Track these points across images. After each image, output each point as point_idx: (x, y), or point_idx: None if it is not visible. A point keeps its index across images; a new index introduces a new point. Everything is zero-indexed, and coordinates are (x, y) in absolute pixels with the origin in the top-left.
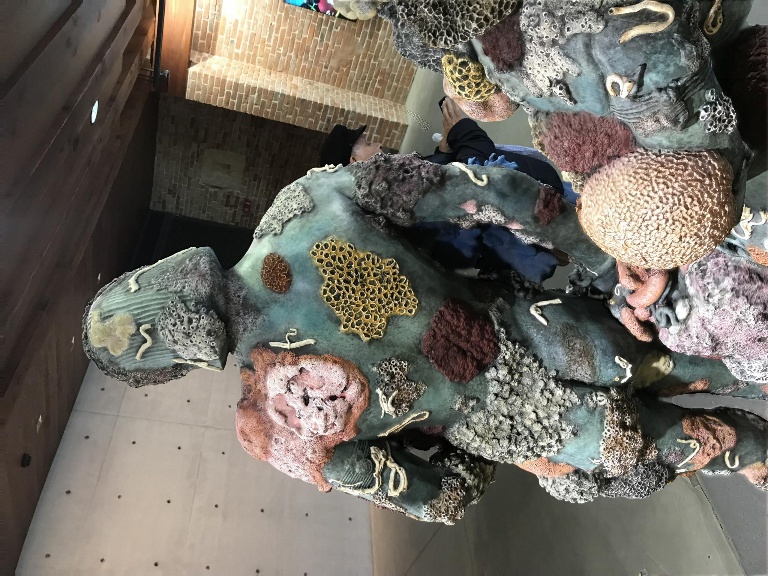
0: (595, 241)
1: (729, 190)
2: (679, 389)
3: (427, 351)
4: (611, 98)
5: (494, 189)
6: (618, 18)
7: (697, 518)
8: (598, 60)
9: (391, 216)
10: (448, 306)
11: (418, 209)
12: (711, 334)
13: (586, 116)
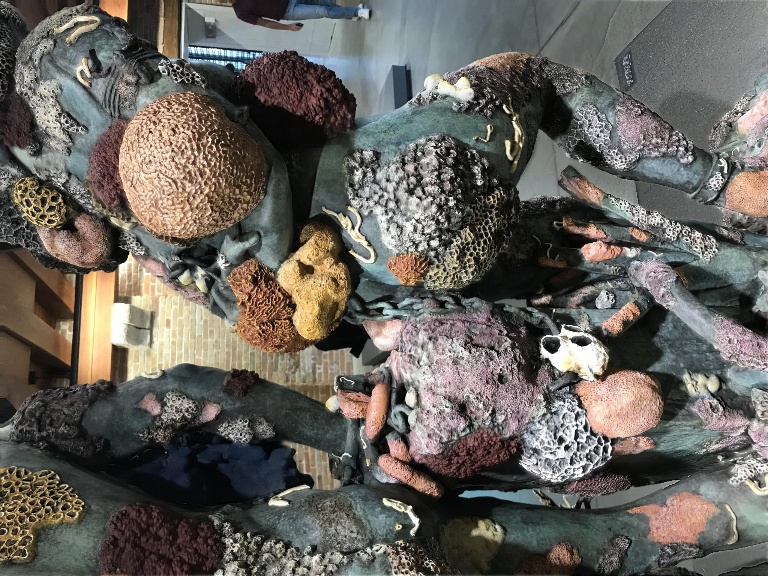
0: (151, 222)
1: (213, 105)
2: (538, 567)
3: (108, 570)
4: (94, 95)
5: (171, 376)
6: (62, 35)
7: None
8: (65, 68)
9: (55, 439)
10: (133, 504)
11: (88, 423)
12: (445, 395)
13: (102, 137)
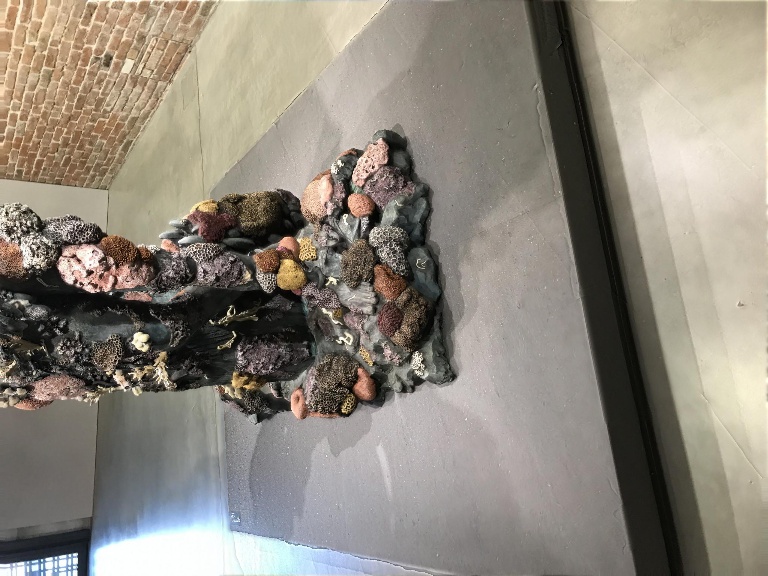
0: None
1: None
2: None
3: None
4: None
5: None
6: None
7: (745, 375)
8: None
9: None
10: None
11: None
12: None
13: None
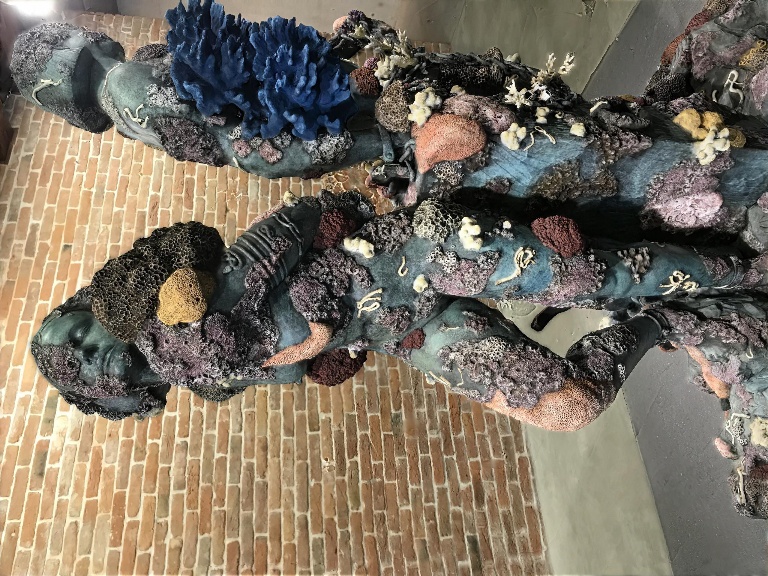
0: None
1: None
2: None
3: None
4: None
5: None
6: None
7: None
8: None
9: None
10: None
11: None
12: None
13: None
